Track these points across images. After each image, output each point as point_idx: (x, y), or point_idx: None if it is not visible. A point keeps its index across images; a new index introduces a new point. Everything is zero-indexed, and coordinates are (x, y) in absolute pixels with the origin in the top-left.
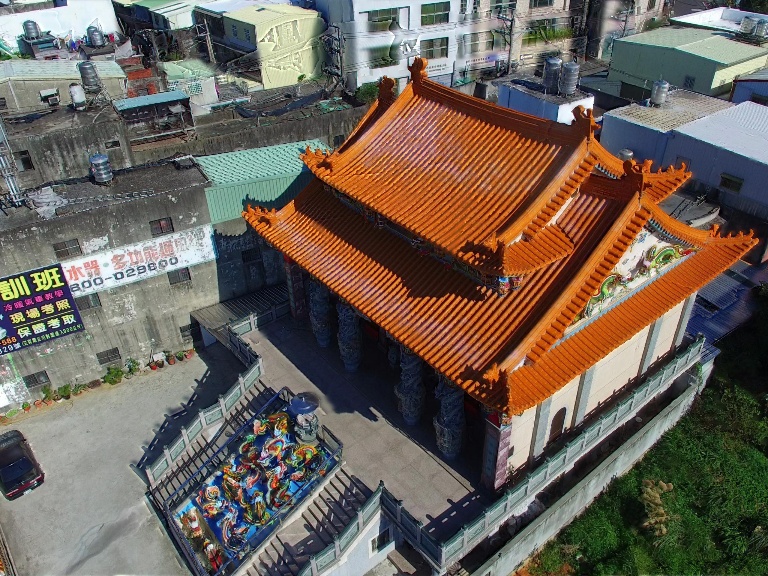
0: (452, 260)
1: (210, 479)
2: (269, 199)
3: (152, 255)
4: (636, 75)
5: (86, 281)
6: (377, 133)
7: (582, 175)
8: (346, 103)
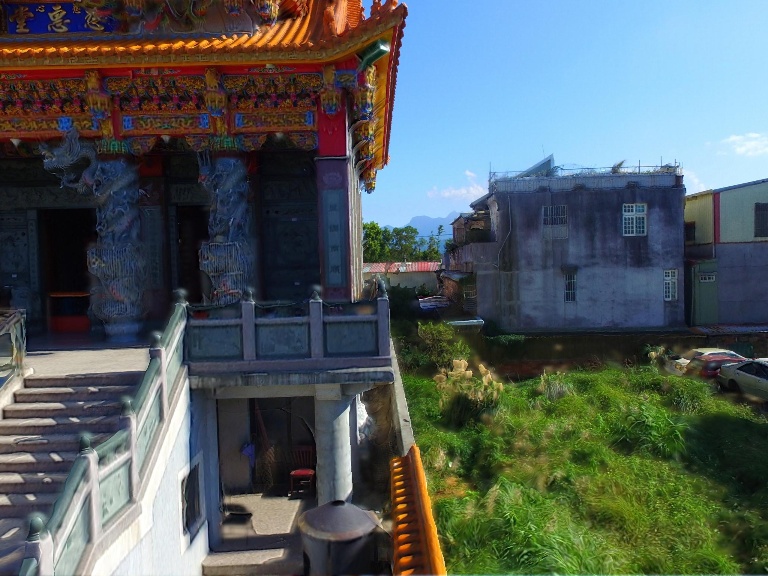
0: (161, 7)
1: None
2: None
3: None
4: None
5: None
6: None
7: None
8: None
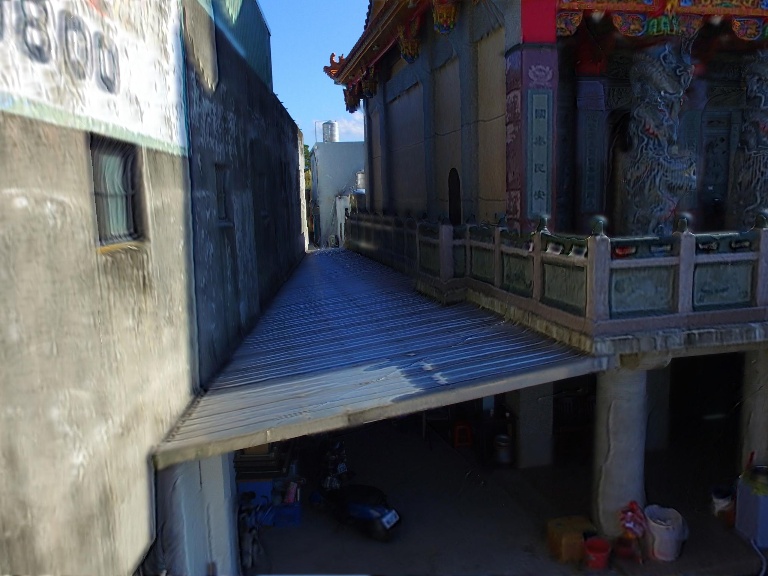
0: None
1: None
2: None
3: None
4: None
5: None
6: None
7: None
8: None
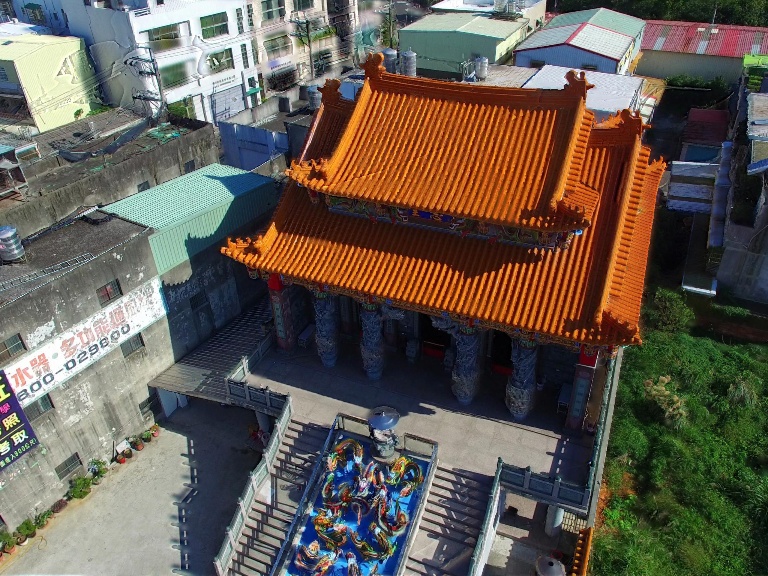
0: (499, 232)
1: (297, 539)
2: (209, 234)
3: (103, 329)
4: (437, 58)
5: (34, 383)
6: (352, 134)
7: (588, 130)
8: None
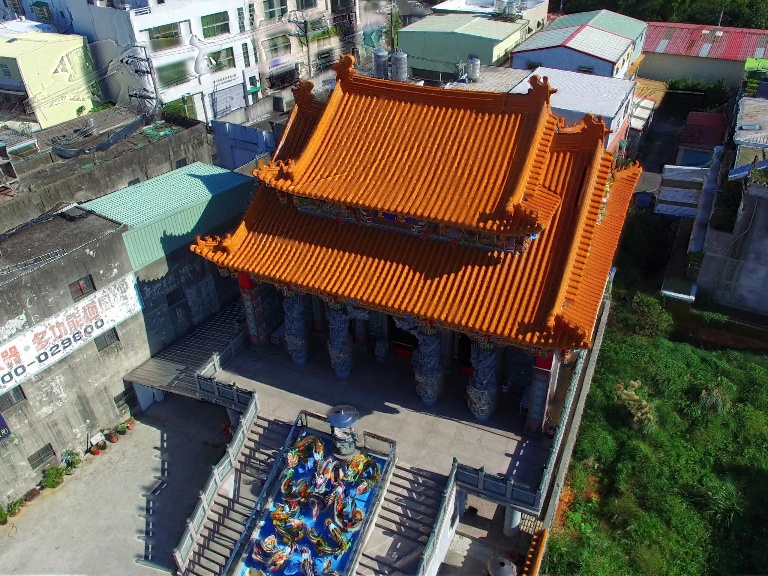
0: (460, 235)
1: (255, 533)
2: (185, 231)
3: (76, 323)
4: (433, 59)
5: (6, 374)
6: (321, 136)
7: (551, 135)
8: (173, 125)
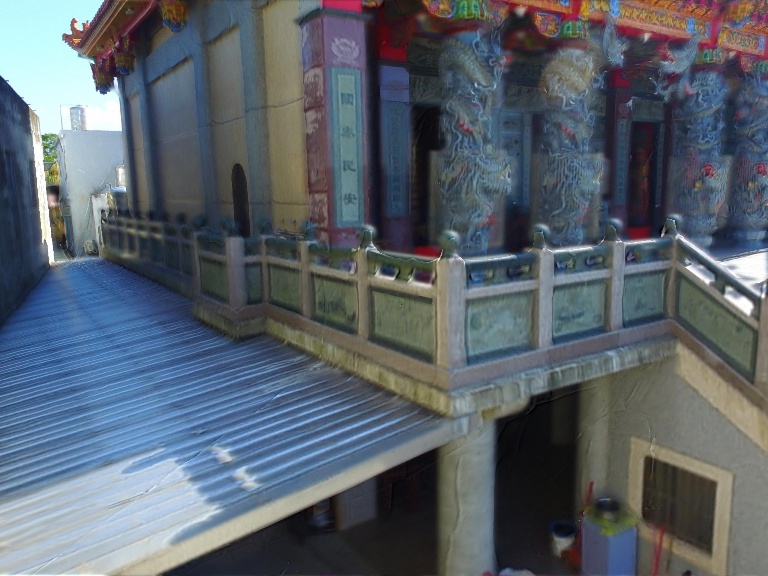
0: None
1: None
2: None
3: None
4: None
5: None
6: None
7: None
8: None
